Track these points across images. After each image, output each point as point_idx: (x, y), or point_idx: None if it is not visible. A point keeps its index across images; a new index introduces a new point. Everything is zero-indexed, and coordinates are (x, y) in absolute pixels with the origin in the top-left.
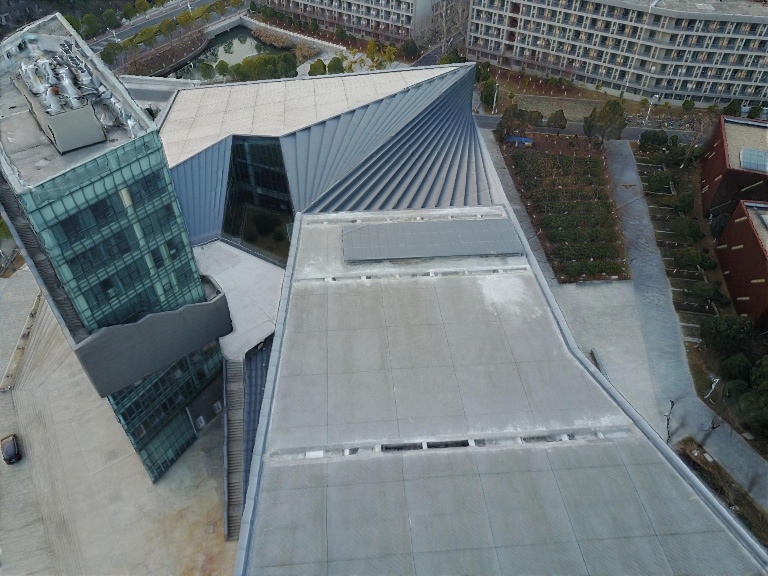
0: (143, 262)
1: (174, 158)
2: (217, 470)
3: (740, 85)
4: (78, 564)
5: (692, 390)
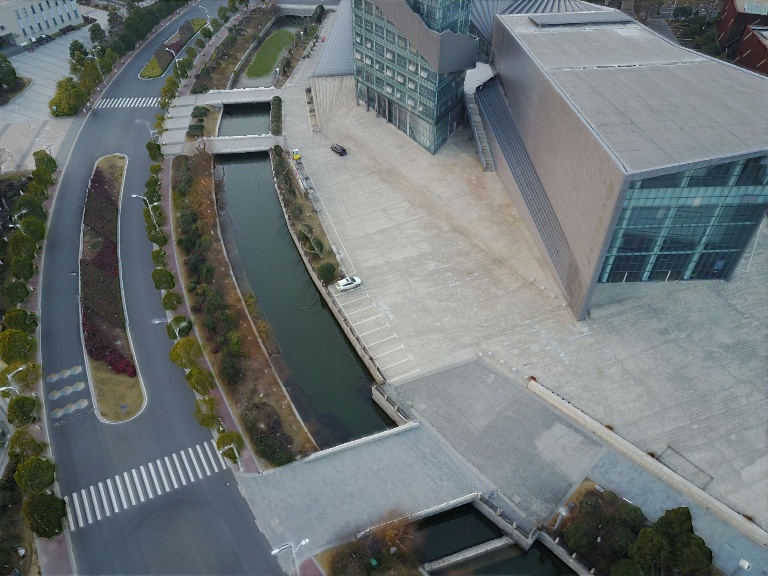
0: (459, 3)
1: None
2: (465, 150)
3: None
4: (409, 181)
5: None
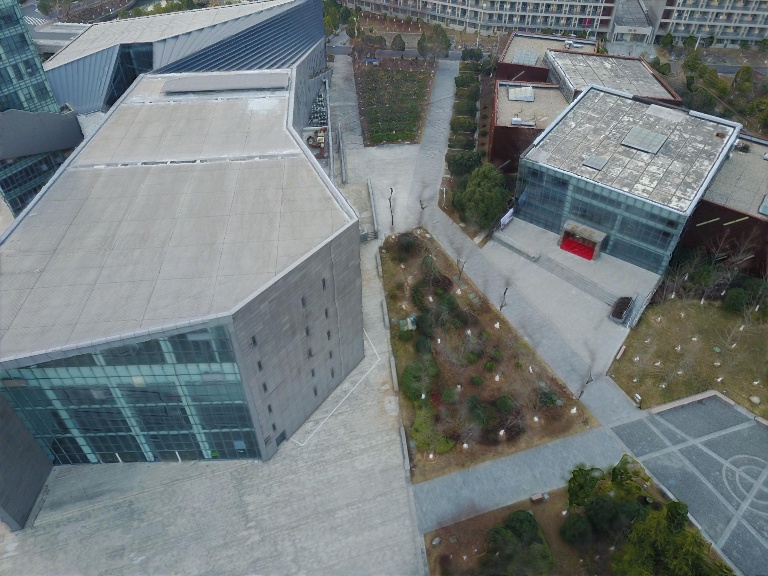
0: (6, 72)
1: (71, 58)
2: None
3: (554, 17)
4: None
5: (435, 203)
